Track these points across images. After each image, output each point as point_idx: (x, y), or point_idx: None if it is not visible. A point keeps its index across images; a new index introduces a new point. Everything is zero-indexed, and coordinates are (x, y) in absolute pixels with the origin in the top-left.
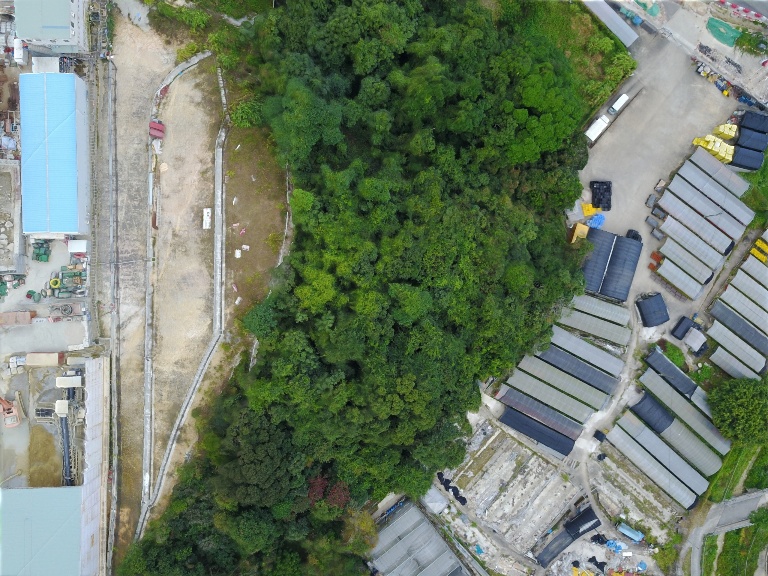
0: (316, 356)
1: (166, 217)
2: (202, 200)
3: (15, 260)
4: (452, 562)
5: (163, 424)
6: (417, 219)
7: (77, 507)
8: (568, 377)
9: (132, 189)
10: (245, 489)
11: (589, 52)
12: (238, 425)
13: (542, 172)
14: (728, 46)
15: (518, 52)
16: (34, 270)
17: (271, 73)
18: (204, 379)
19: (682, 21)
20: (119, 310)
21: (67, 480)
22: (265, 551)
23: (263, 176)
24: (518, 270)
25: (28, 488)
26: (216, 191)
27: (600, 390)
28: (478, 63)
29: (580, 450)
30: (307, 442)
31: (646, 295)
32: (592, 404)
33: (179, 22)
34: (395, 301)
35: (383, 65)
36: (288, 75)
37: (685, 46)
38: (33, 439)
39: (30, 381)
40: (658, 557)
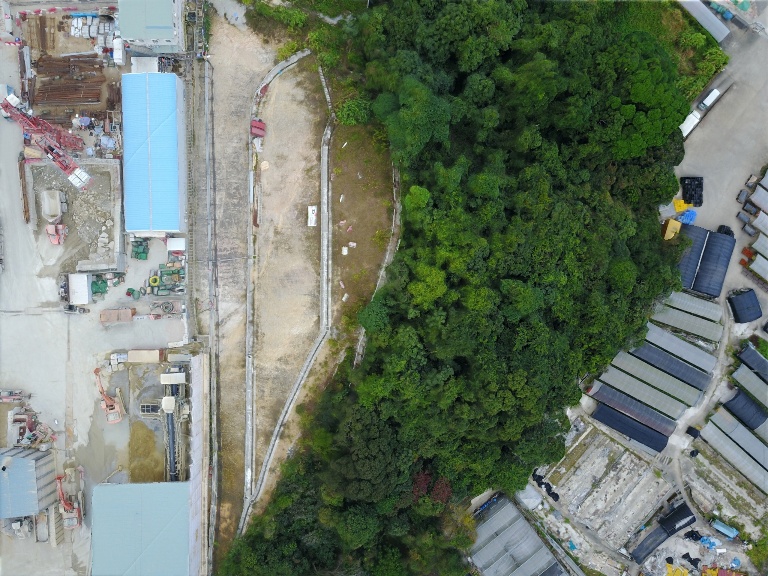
0: (426, 352)
1: (267, 215)
2: (307, 198)
3: (116, 258)
4: (549, 558)
5: (265, 420)
6: (524, 215)
7: (185, 502)
8: (661, 373)
9: (231, 187)
10: (358, 484)
11: (681, 47)
12: (351, 421)
13: (638, 168)
14: None
15: (625, 48)
16: (133, 268)
17: (379, 71)
18: (309, 375)
19: None
20: (218, 307)
21: (172, 476)
22: (366, 546)
23: (369, 173)
24: (623, 266)
25: (137, 483)
26: (322, 189)
27: (693, 386)
28: (584, 59)
29: (672, 446)
30: (412, 438)
31: (738, 291)
32: (685, 400)
33: (276, 21)
34: (505, 297)
35: (486, 62)
36: (399, 73)
37: None
38: (134, 435)
39: (130, 378)
40: (752, 554)
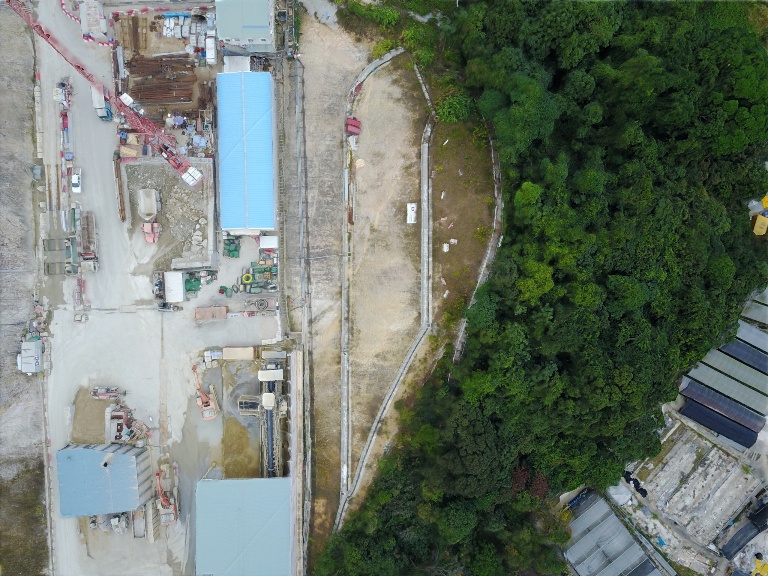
0: (531, 348)
1: (363, 212)
2: (406, 195)
3: (210, 256)
4: (641, 553)
5: (362, 416)
6: (627, 211)
7: (286, 498)
8: (749, 369)
9: (324, 185)
10: (466, 480)
11: None
12: (458, 416)
13: (730, 164)
14: None
15: (727, 43)
16: (225, 266)
17: (482, 68)
18: (408, 372)
19: None
20: (311, 305)
21: (270, 472)
22: (462, 542)
23: (470, 170)
24: (723, 262)
25: (239, 479)
26: (423, 186)
27: None
28: (686, 55)
29: (761, 442)
30: (512, 434)
31: None
32: None
33: (367, 20)
34: (611, 293)
35: (585, 59)
36: (504, 70)
37: None
38: (227, 432)
39: (224, 375)
40: None
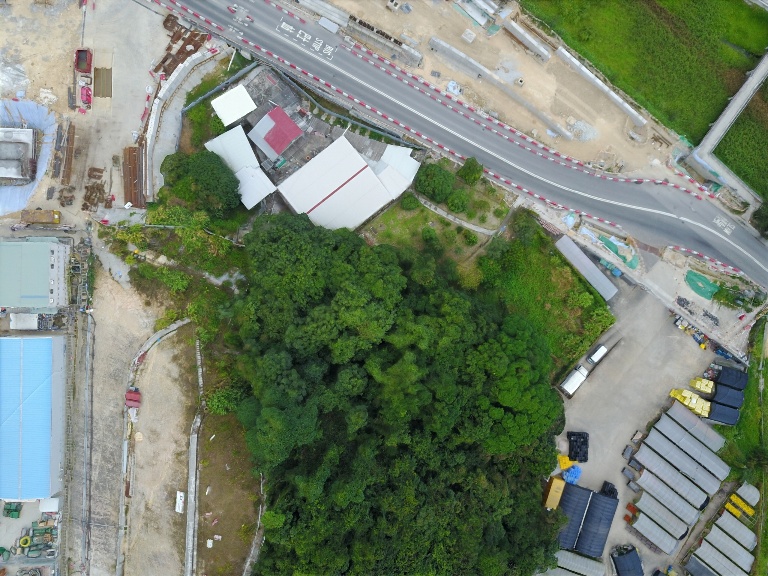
0: None
1: (139, 487)
2: (176, 482)
3: None
4: None
5: None
6: (391, 515)
7: None
8: None
9: (107, 451)
10: None
11: (568, 307)
12: None
13: None
14: (706, 299)
15: (495, 349)
16: (4, 525)
17: (248, 369)
18: None
19: (661, 273)
20: (89, 572)
21: None
22: None
23: (237, 465)
24: (491, 561)
25: None
26: (190, 478)
27: None
28: (455, 358)
29: None
30: None
31: (621, 547)
32: None
33: (160, 281)
34: None
35: (361, 350)
36: (264, 379)
37: (664, 298)
38: None
39: None
40: None
